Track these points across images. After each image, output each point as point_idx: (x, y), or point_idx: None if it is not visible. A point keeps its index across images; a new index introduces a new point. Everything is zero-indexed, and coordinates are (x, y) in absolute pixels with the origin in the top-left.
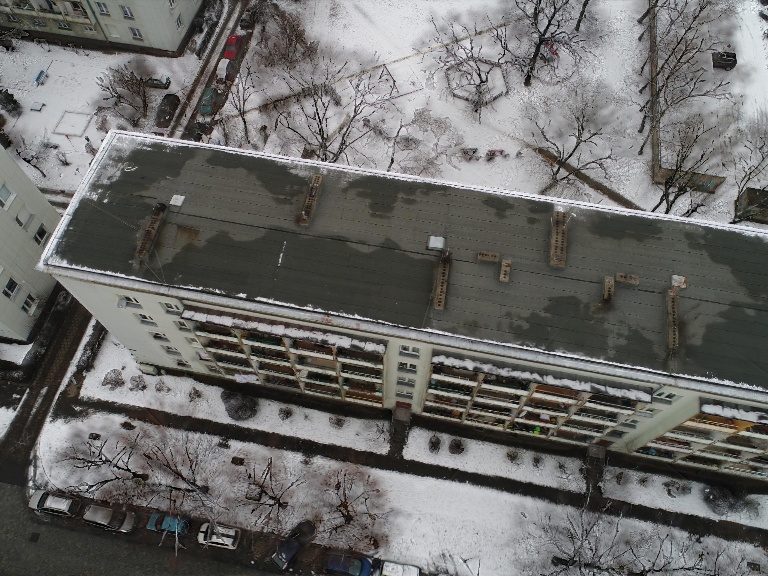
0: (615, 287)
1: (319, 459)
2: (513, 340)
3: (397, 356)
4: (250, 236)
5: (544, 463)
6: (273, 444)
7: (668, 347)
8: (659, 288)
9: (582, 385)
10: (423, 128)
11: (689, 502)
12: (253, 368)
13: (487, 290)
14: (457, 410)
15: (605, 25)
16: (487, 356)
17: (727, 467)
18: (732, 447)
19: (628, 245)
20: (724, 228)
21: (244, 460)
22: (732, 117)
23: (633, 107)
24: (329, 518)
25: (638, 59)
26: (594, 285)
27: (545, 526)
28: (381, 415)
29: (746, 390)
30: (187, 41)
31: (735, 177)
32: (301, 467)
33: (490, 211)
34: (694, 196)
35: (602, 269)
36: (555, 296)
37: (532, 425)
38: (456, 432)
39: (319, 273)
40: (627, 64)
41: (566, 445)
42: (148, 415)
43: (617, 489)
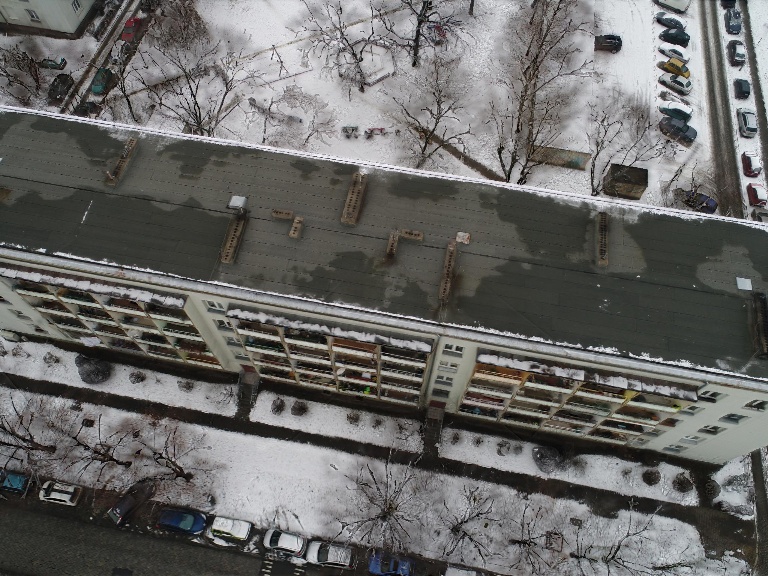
0: (401, 243)
1: (167, 421)
2: (295, 292)
3: (207, 313)
4: (59, 195)
5: (385, 425)
6: (124, 407)
7: (438, 298)
8: (443, 244)
9: (367, 336)
10: (291, 104)
11: (521, 462)
12: (90, 329)
13: (278, 246)
14: (285, 370)
15: (499, 9)
16: (279, 309)
17: (546, 425)
18: (532, 401)
19: (422, 204)
20: (519, 189)
21: (94, 422)
22: (612, 98)
23: (516, 88)
24: (170, 477)
25: (527, 42)
26: (381, 241)
27: (358, 479)
28: (232, 380)
29: (509, 338)
30: (88, 24)
31: (589, 151)
32: (149, 429)
33: (296, 173)
34: (565, 173)
35: (392, 226)
36: (342, 251)
37: (363, 385)
38: (303, 396)
39: (119, 230)
40: (505, 45)
41: (408, 408)
42: (6, 379)
43: (453, 449)
